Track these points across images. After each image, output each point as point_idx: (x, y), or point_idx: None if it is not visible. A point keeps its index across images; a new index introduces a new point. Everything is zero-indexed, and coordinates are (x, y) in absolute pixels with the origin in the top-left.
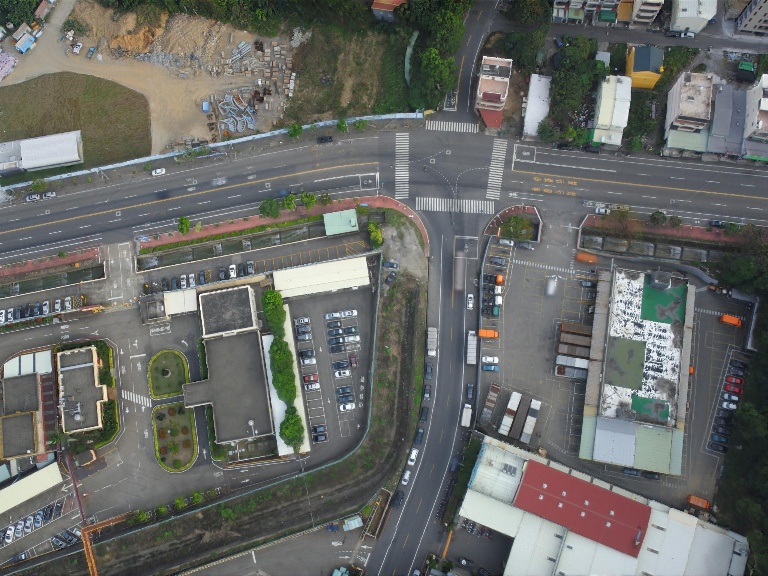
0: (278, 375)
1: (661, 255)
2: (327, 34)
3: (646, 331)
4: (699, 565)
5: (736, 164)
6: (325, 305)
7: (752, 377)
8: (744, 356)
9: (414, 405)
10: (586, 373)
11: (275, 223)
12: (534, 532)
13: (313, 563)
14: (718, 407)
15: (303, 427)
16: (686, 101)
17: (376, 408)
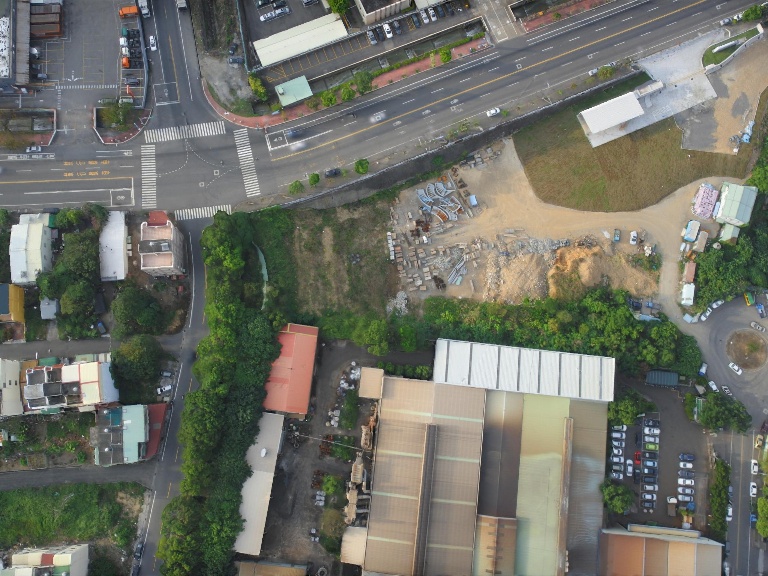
0: None
1: None
2: (369, 312)
3: None
4: None
5: None
6: (293, 21)
7: None
8: None
9: None
10: None
11: None
12: None
13: None
14: None
15: None
16: None
17: None
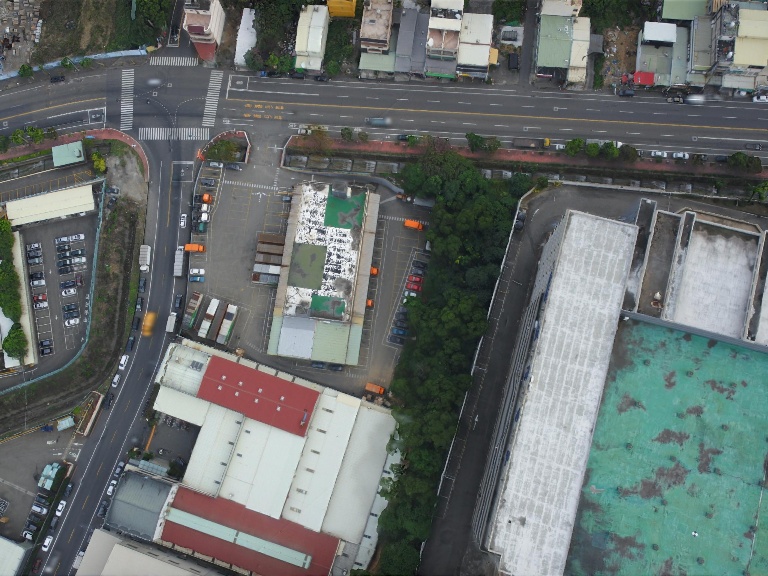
0: (1, 294)
1: (357, 170)
2: None
3: (328, 236)
4: (363, 442)
5: (424, 82)
6: (56, 231)
7: (429, 275)
8: (426, 257)
9: (128, 316)
10: (278, 278)
11: (11, 158)
12: (218, 420)
13: (29, 461)
14: (399, 304)
15: (27, 341)
16: (368, 24)
17: (95, 321)
